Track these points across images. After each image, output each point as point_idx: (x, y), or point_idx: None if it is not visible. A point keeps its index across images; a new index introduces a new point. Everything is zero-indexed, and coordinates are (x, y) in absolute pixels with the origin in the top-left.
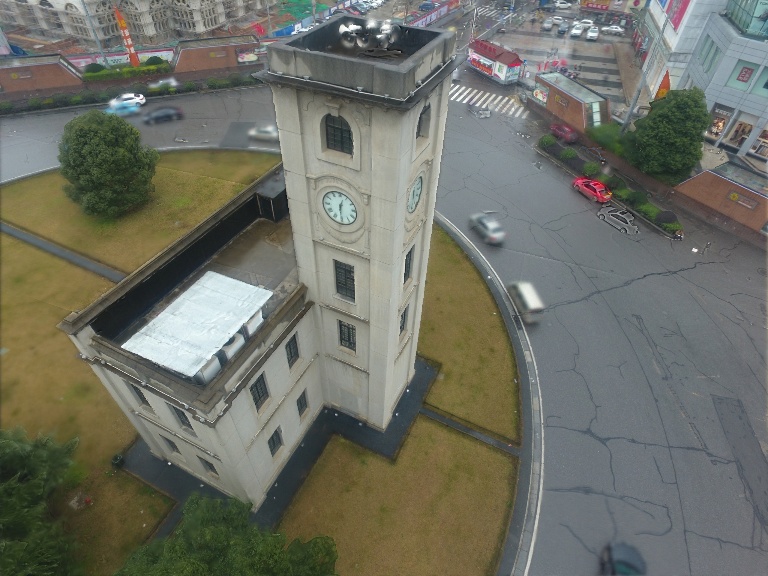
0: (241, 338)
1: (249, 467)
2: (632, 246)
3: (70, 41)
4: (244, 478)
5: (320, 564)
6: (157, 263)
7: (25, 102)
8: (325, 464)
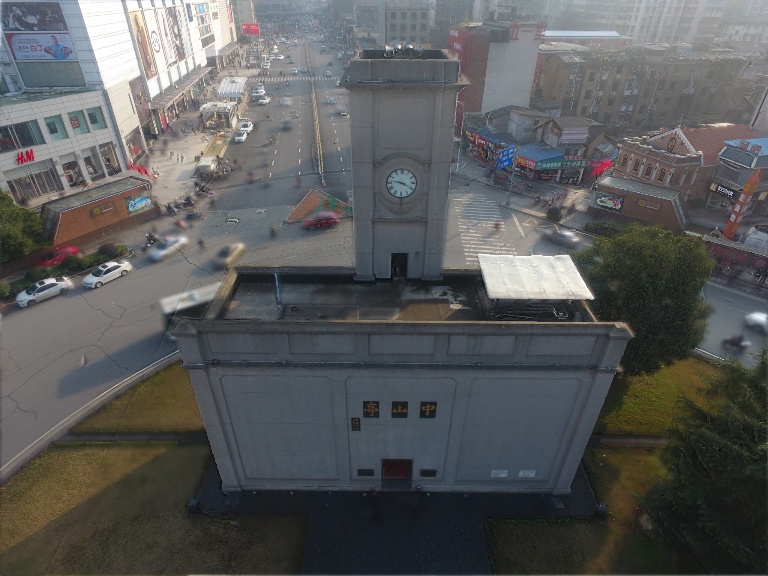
0: None
1: None
2: (147, 270)
3: None
4: None
5: None
6: None
7: None
8: None
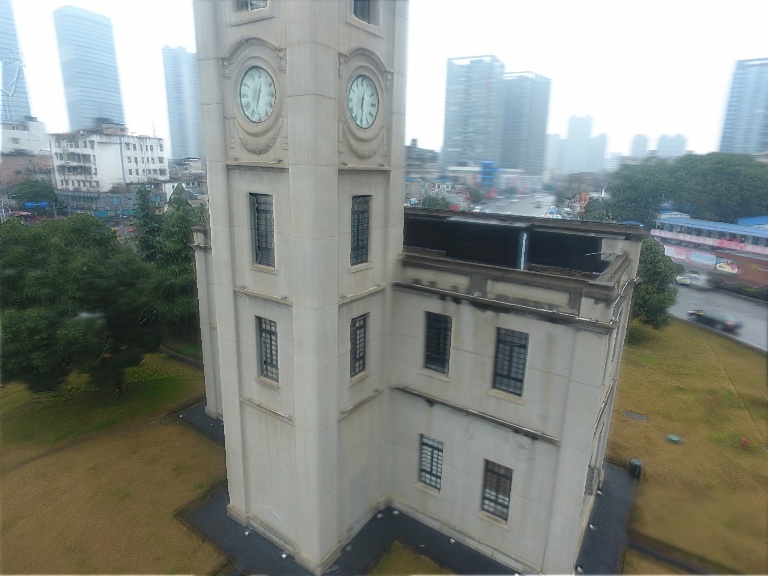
0: None
1: (210, 348)
2: None
3: None
4: (205, 350)
5: None
6: None
7: None
8: (221, 456)
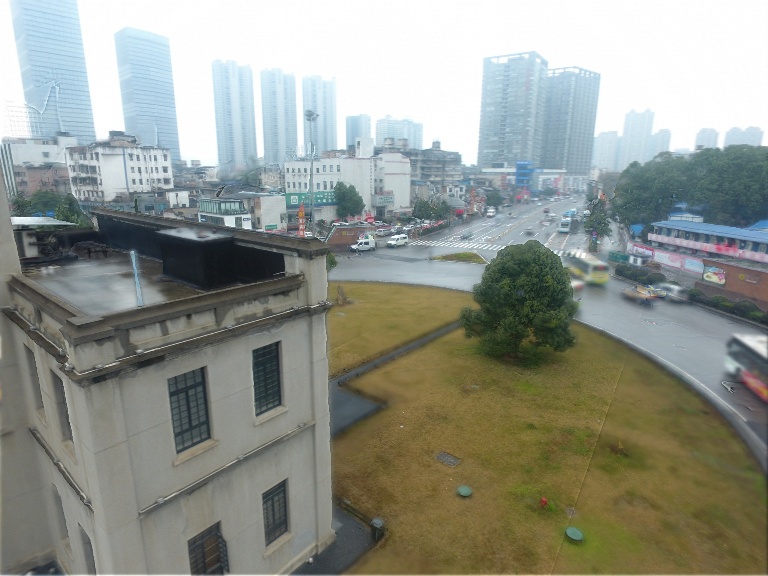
0: None
1: None
2: None
3: None
4: None
5: None
6: None
7: None
8: None
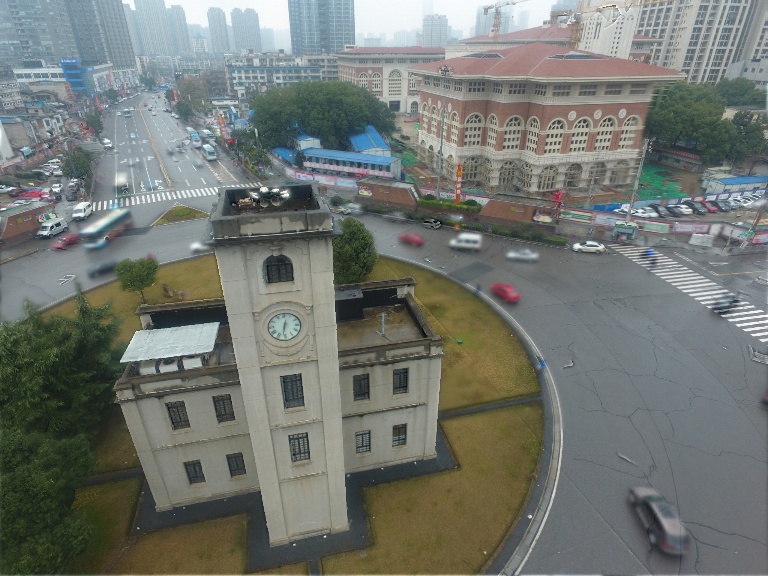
0: (175, 366)
1: (155, 465)
2: None
3: (441, 178)
4: (148, 470)
5: (68, 538)
6: (208, 303)
7: (375, 207)
8: (217, 526)
